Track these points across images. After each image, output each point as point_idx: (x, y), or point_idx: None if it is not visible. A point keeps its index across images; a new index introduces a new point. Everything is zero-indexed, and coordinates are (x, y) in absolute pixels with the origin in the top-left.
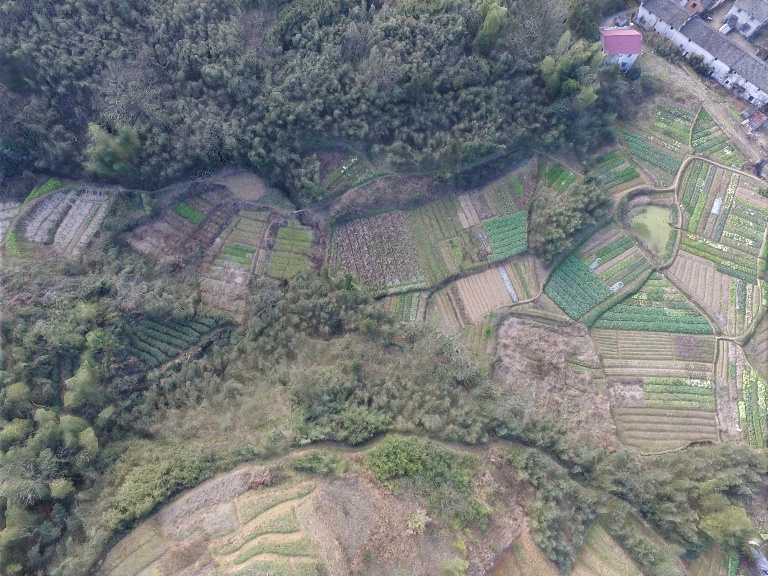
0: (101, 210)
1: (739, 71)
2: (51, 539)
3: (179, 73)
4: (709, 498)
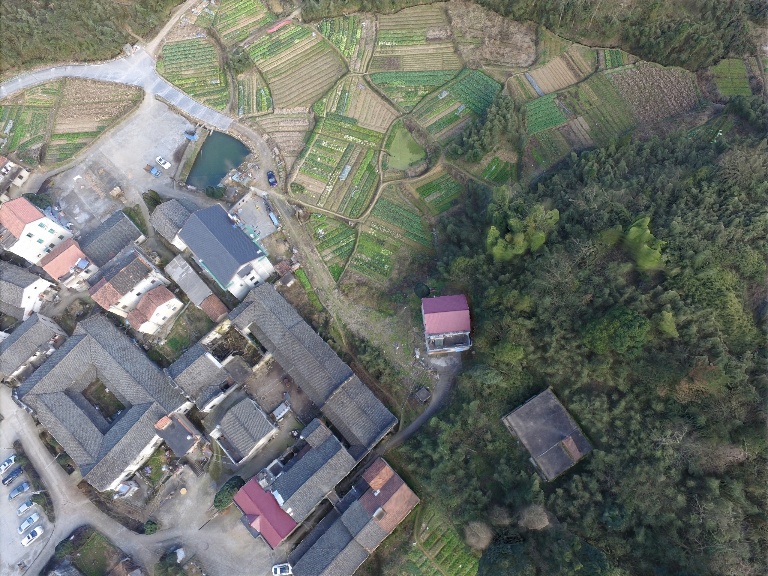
0: None
1: (296, 314)
2: None
3: None
4: None
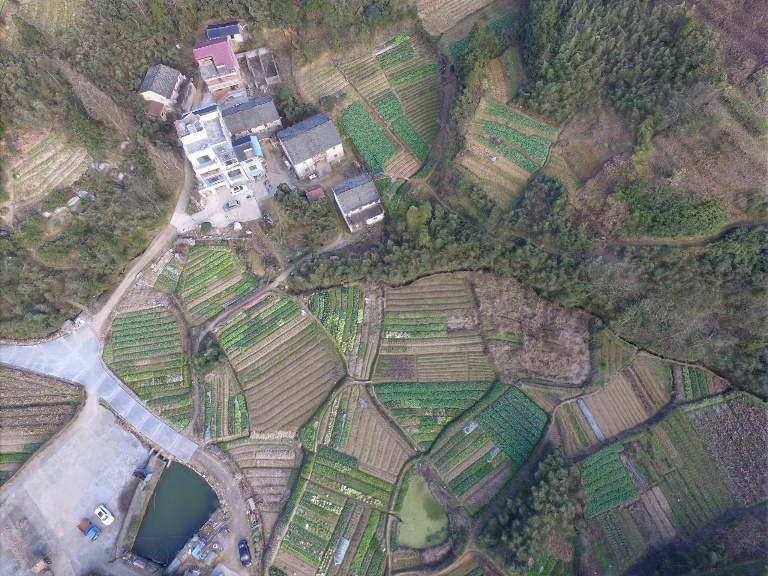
0: None
1: None
2: None
3: None
4: None
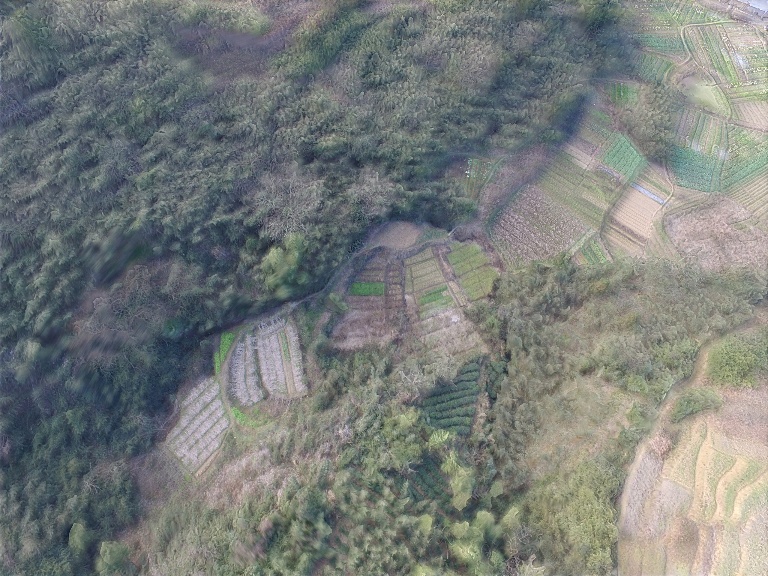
0: (290, 335)
1: None
2: None
3: (295, 163)
4: None
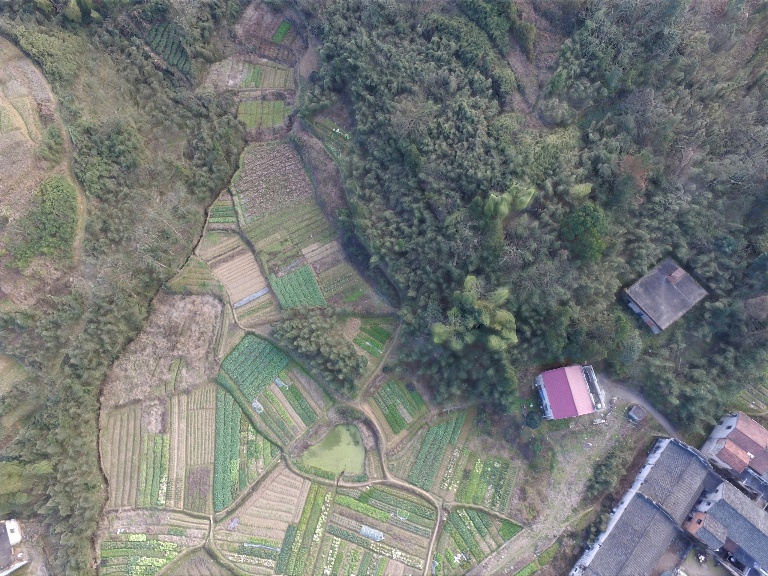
0: None
1: None
2: (13, 7)
3: None
4: (31, 465)
